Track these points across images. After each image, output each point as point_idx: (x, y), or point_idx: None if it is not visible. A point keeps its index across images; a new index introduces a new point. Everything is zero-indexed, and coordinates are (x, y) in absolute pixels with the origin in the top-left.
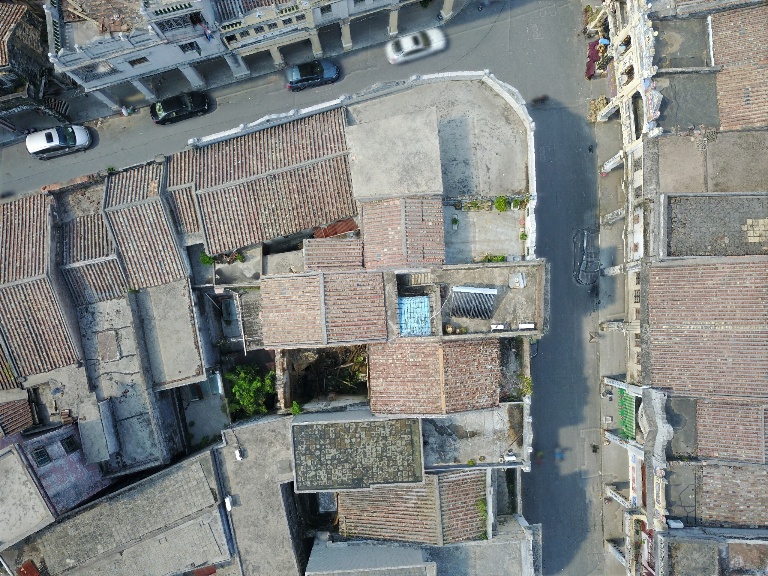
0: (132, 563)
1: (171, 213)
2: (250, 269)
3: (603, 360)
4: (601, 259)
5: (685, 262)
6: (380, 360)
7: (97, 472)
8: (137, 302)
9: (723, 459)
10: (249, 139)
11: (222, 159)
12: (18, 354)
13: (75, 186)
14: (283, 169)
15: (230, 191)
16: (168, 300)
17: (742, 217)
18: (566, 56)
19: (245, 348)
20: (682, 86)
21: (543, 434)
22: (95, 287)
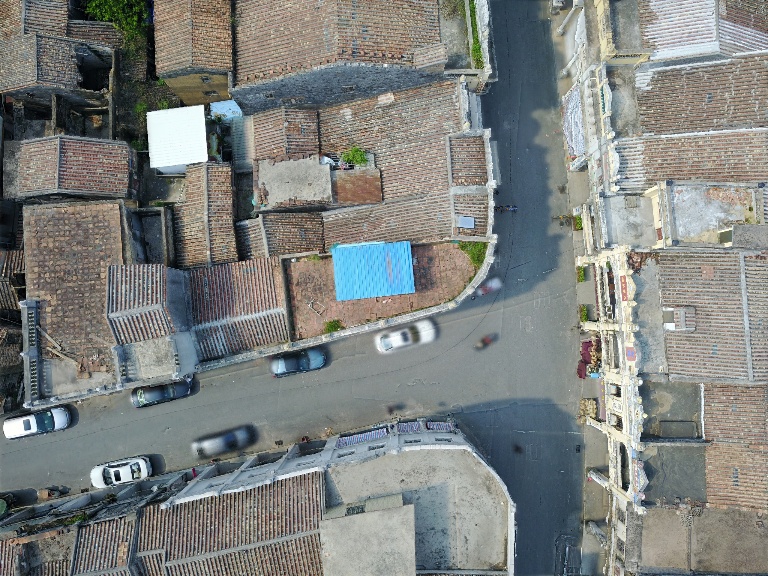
0: None
1: (140, 574)
2: None
3: None
4: (583, 565)
5: None
6: None
7: None
8: None
9: None
10: (224, 498)
11: (195, 521)
12: None
13: None
14: (256, 545)
15: (201, 562)
16: None
17: None
18: (558, 351)
19: None
20: (670, 456)
21: None
22: None
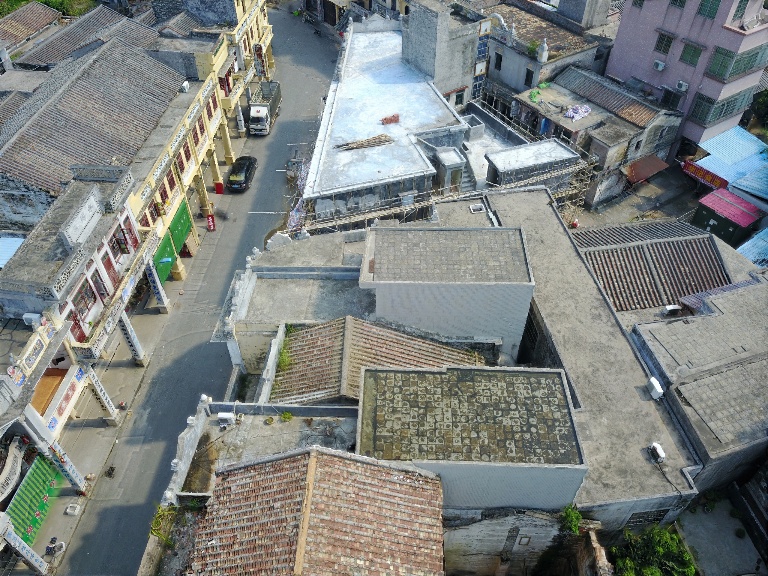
0: None
1: None
2: None
3: None
4: None
5: None
6: (423, 575)
7: None
8: None
9: None
10: None
11: None
12: None
13: None
14: None
15: None
16: None
17: None
18: None
19: None
20: None
21: None
22: None
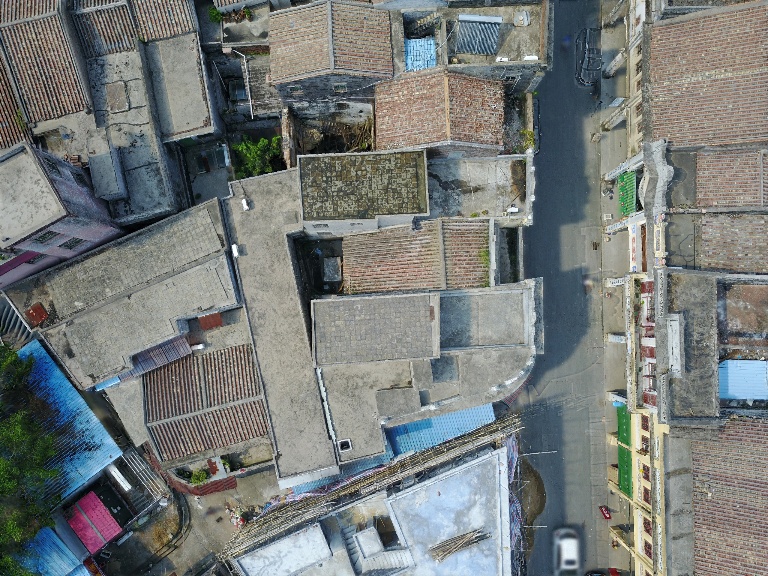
0: (140, 307)
1: None
2: (258, 28)
3: (604, 160)
4: None
5: (686, 17)
6: (386, 99)
7: (106, 214)
8: (146, 55)
9: (722, 207)
10: None
11: None
12: (28, 98)
13: None
14: None
15: None
16: (177, 54)
17: None
18: None
19: (252, 112)
20: None
21: (544, 231)
22: (105, 37)
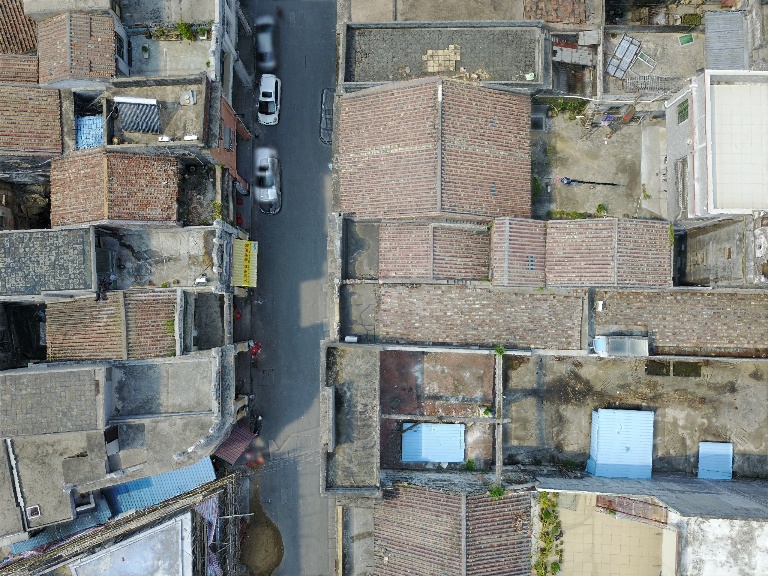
0: None
1: None
2: None
3: None
4: None
5: (368, 91)
6: (59, 176)
7: None
8: None
9: (399, 278)
10: None
11: None
12: None
13: None
14: None
15: None
16: None
17: (423, 48)
18: None
19: None
20: None
21: (287, 288)
22: None
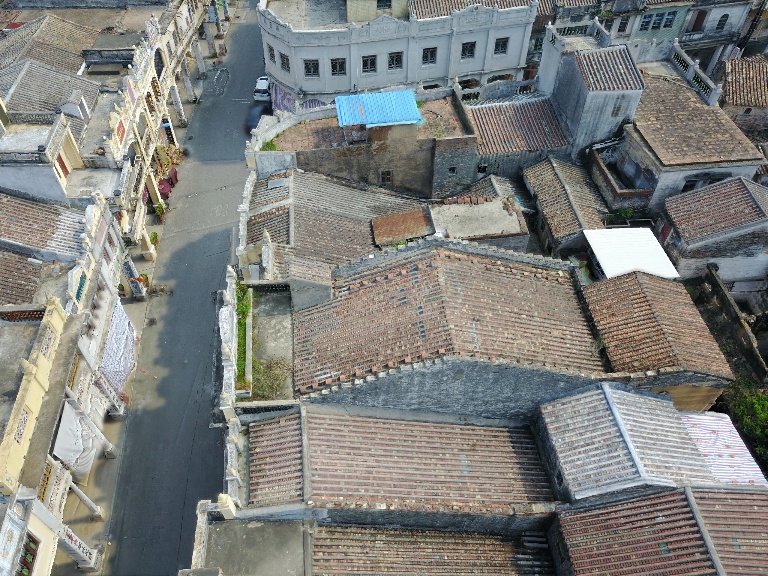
0: None
1: None
2: None
3: None
4: None
5: None
6: None
7: None
8: None
9: None
10: None
11: (510, 3)
12: None
13: (625, 5)
14: None
15: None
16: None
17: None
18: None
19: None
20: None
21: None
22: None
